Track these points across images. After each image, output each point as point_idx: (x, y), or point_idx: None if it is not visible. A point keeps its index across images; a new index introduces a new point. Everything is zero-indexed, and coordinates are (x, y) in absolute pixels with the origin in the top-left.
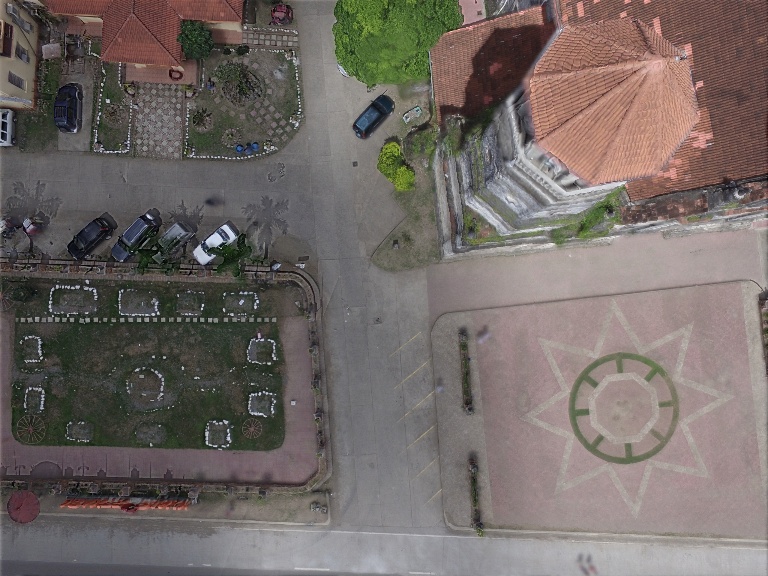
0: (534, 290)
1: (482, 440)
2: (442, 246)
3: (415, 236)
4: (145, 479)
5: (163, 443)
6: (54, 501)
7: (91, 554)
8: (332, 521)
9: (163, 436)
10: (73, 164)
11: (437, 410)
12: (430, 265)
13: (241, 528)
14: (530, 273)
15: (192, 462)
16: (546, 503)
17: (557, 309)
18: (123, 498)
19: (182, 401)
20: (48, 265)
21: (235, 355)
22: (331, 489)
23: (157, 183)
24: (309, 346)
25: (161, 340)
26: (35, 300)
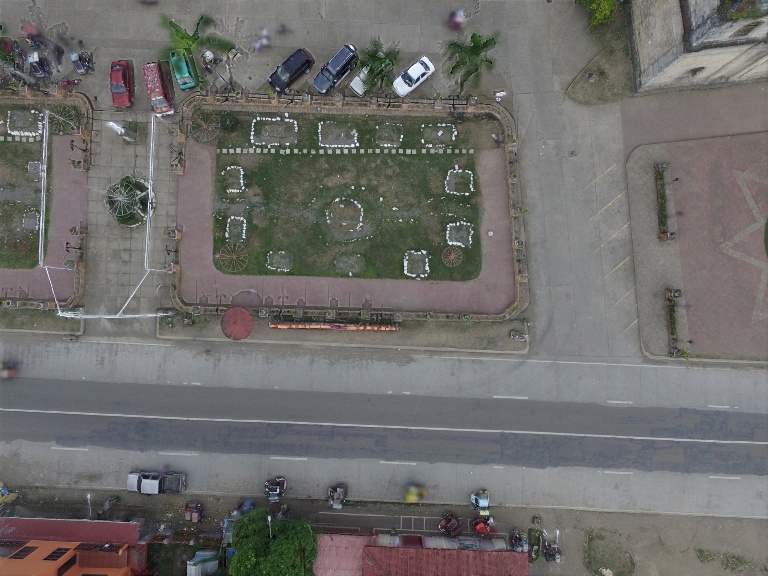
0: (728, 123)
1: (678, 270)
2: (639, 77)
3: (610, 70)
4: (344, 308)
5: (362, 273)
6: (256, 328)
7: (292, 381)
8: (529, 350)
9: (362, 265)
10: (271, 1)
11: (633, 241)
12: (624, 99)
13: (440, 356)
14: (723, 106)
15: (390, 292)
16: (743, 333)
17: (751, 141)
18: (326, 323)
19: (380, 231)
20: (249, 98)
21: (433, 186)
22: (528, 319)
23: (354, 19)
24: (507, 176)
25: (360, 171)
26: (238, 130)
